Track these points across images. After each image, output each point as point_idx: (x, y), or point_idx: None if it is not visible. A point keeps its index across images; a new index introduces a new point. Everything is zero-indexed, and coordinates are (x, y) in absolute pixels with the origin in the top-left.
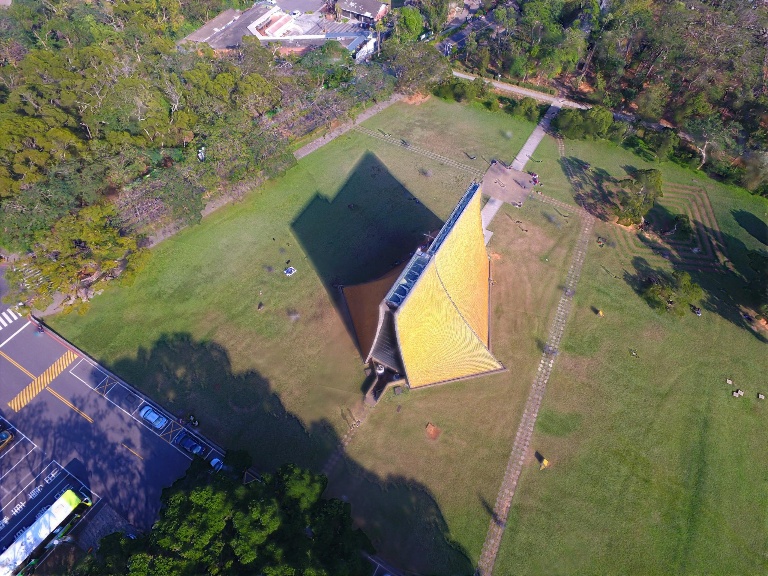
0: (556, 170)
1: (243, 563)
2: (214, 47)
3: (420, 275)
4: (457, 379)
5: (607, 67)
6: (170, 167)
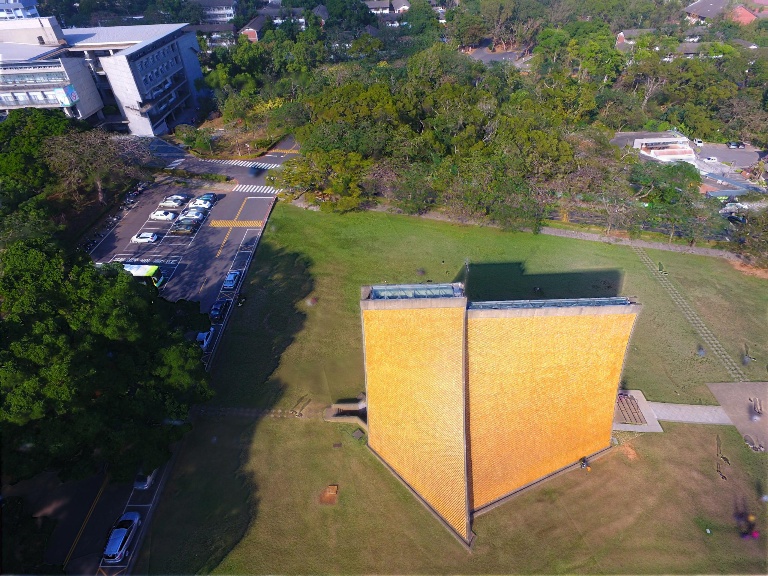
0: None
1: (69, 323)
2: None
3: (425, 298)
4: (412, 489)
5: None
6: None
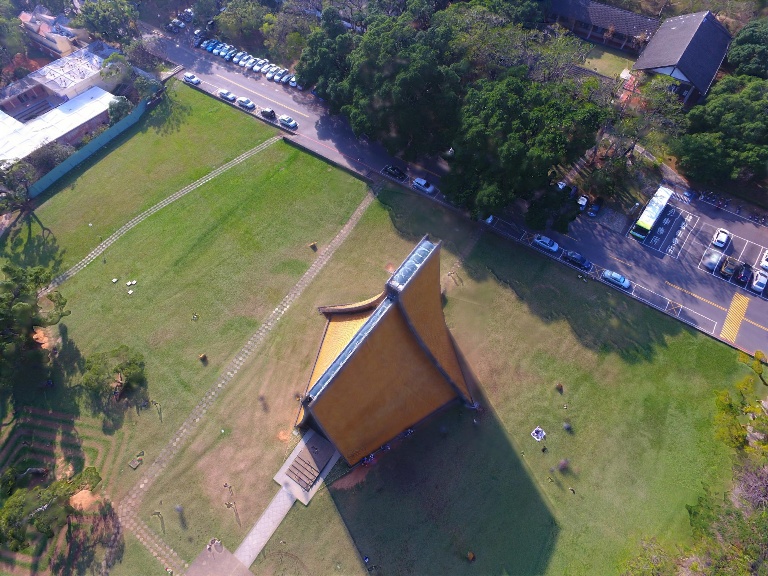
0: None
1: None
2: None
3: (403, 263)
4: None
5: None
6: None
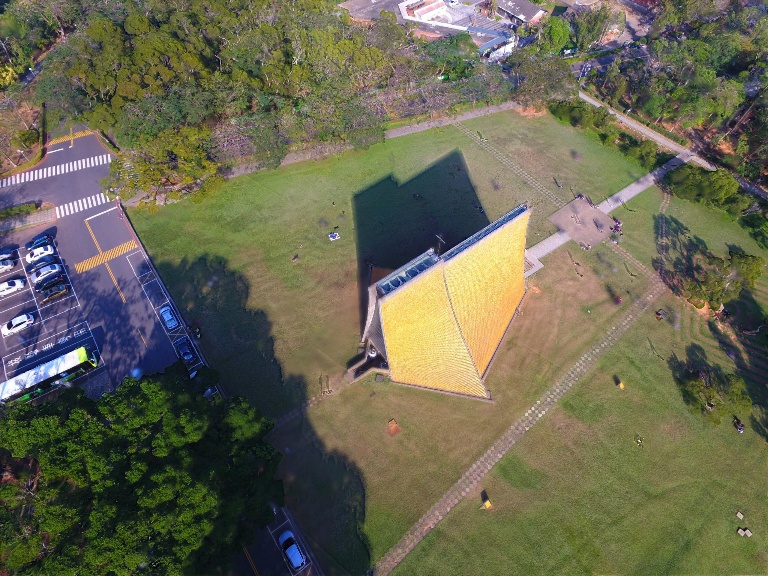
0: (646, 225)
1: (154, 454)
2: (361, 16)
3: (420, 273)
4: (439, 390)
5: (761, 132)
6: (268, 112)
